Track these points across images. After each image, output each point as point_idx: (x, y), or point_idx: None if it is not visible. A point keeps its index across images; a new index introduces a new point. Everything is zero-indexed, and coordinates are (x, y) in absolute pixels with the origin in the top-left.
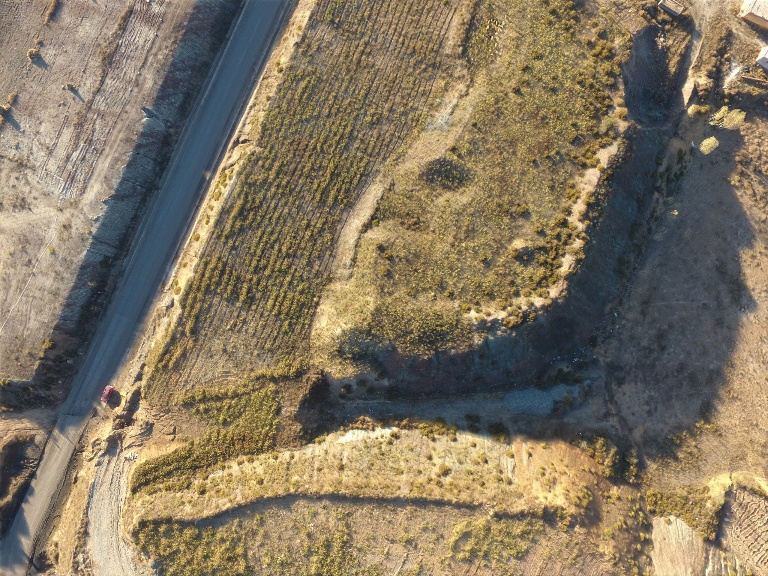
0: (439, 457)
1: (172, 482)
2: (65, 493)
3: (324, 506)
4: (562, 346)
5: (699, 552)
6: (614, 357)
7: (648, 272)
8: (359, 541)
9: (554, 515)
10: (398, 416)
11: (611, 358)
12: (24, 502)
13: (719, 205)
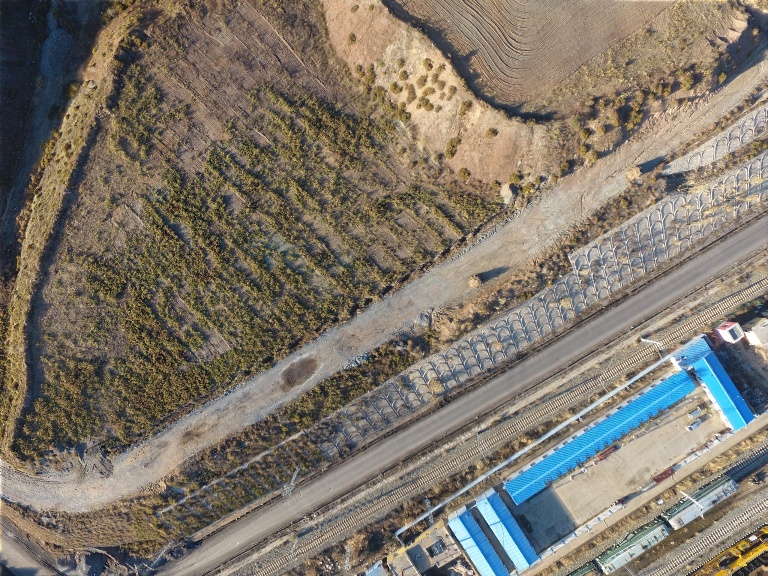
0: (61, 152)
1: (3, 413)
2: (8, 523)
3: (54, 271)
4: (11, 5)
5: None
6: None
7: None
8: (99, 248)
9: (130, 52)
10: (28, 184)
11: None
12: (6, 565)
13: None
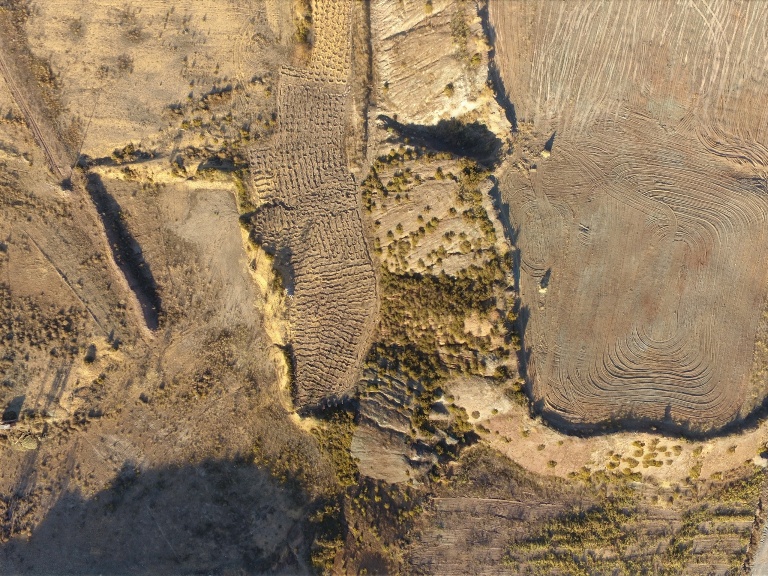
0: None
1: None
2: None
3: None
4: None
5: (368, 433)
6: (238, 567)
7: (148, 570)
8: None
9: None
10: None
11: (240, 569)
12: None
13: (56, 536)
